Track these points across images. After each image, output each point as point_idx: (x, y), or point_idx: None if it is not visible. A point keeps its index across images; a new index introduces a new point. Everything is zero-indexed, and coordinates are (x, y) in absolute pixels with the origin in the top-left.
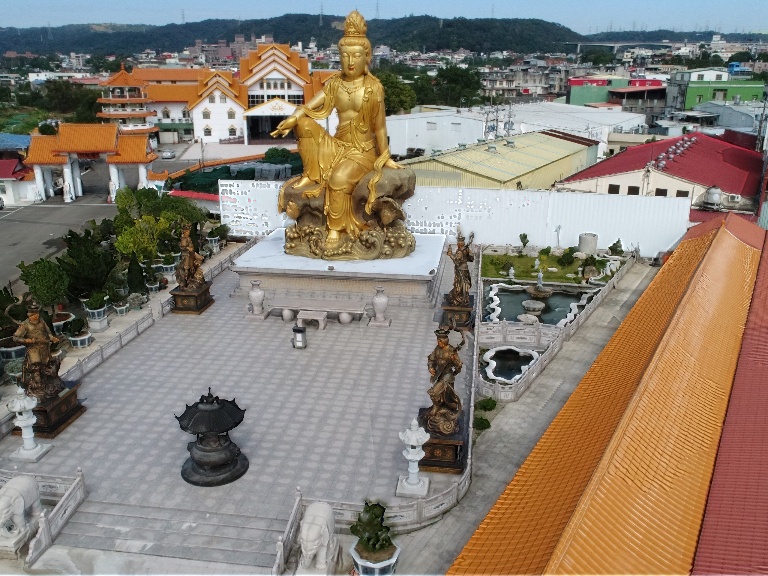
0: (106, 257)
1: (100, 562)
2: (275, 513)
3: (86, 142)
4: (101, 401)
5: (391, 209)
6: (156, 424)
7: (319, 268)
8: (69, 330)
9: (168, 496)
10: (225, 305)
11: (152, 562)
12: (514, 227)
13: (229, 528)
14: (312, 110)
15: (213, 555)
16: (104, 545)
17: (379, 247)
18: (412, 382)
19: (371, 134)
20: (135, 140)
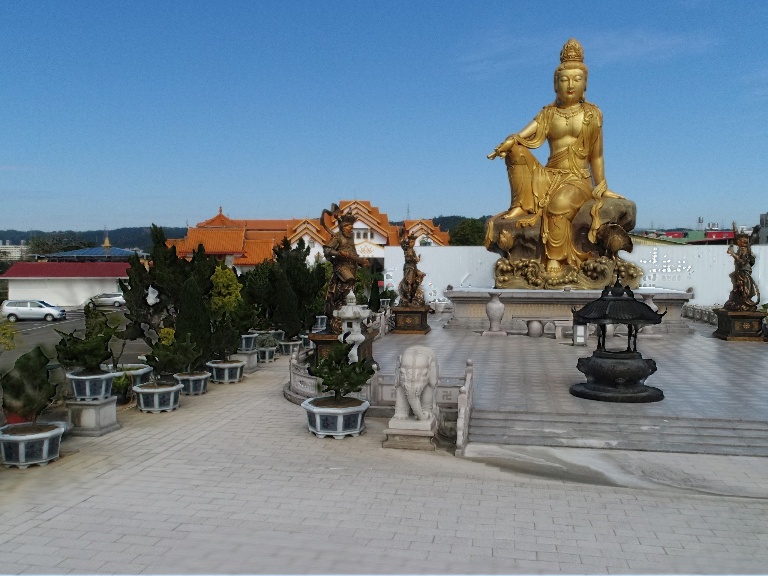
0: (320, 270)
1: (560, 453)
2: (764, 417)
3: (214, 244)
4: (389, 365)
5: (619, 236)
6: (484, 375)
7: (552, 291)
8: (302, 325)
9: (587, 407)
10: (446, 331)
11: (639, 454)
12: (720, 286)
13: (713, 429)
14: (524, 138)
15: (724, 449)
16: (546, 441)
17: (610, 275)
18: (761, 360)
19: (587, 163)
20: (261, 244)
